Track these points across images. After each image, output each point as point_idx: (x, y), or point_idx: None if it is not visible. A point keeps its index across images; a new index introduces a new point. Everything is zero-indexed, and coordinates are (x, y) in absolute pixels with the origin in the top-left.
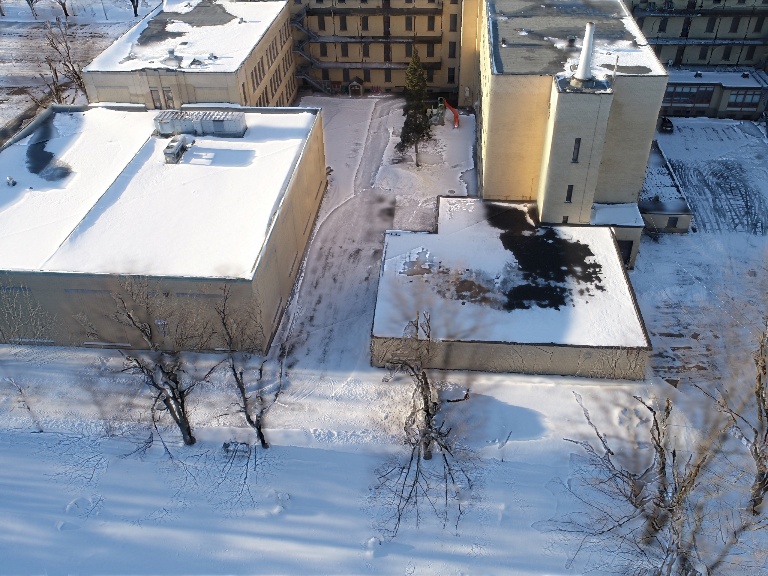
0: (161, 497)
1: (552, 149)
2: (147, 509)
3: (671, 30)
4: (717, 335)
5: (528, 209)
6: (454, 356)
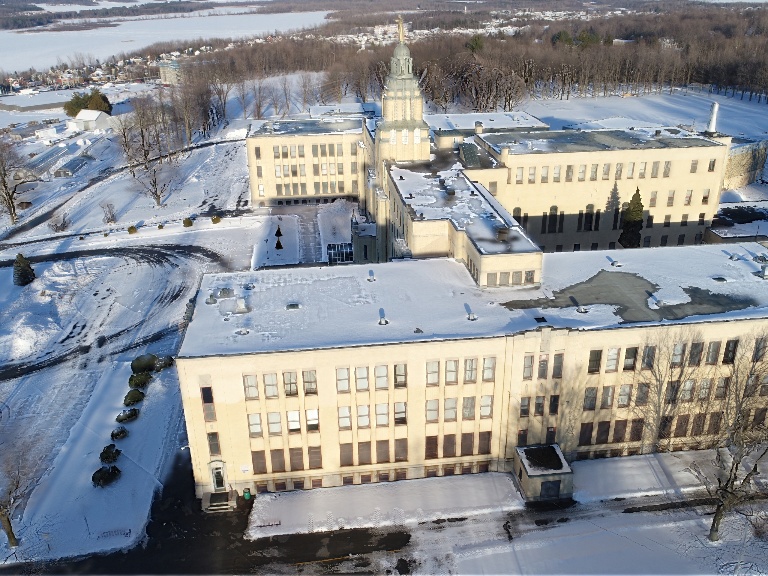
0: None
1: None
2: None
3: None
4: None
5: None
6: None
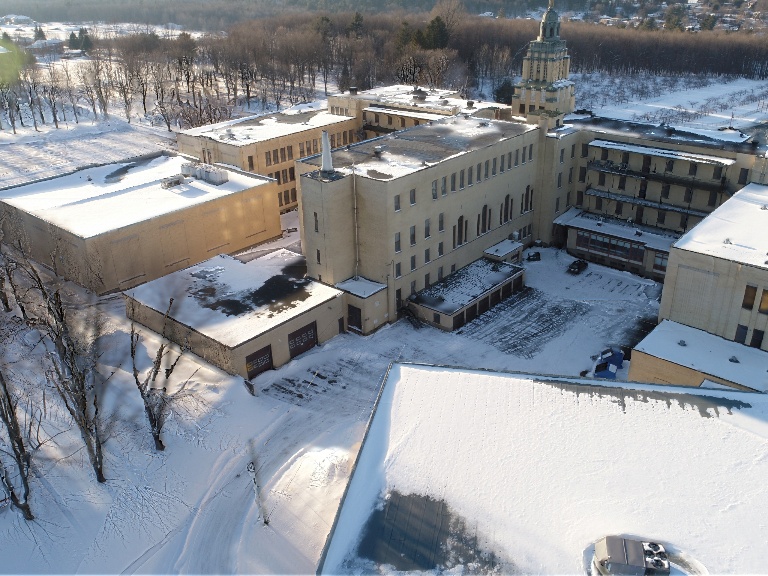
0: None
1: (304, 218)
2: None
3: (629, 189)
4: (346, 387)
5: None
6: None
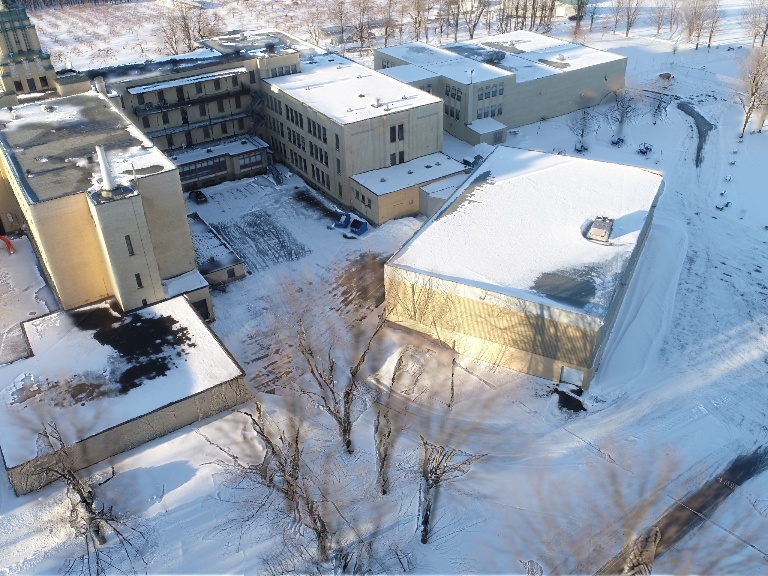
0: None
1: (109, 251)
2: None
3: (173, 121)
4: (291, 344)
5: (110, 305)
6: (93, 451)
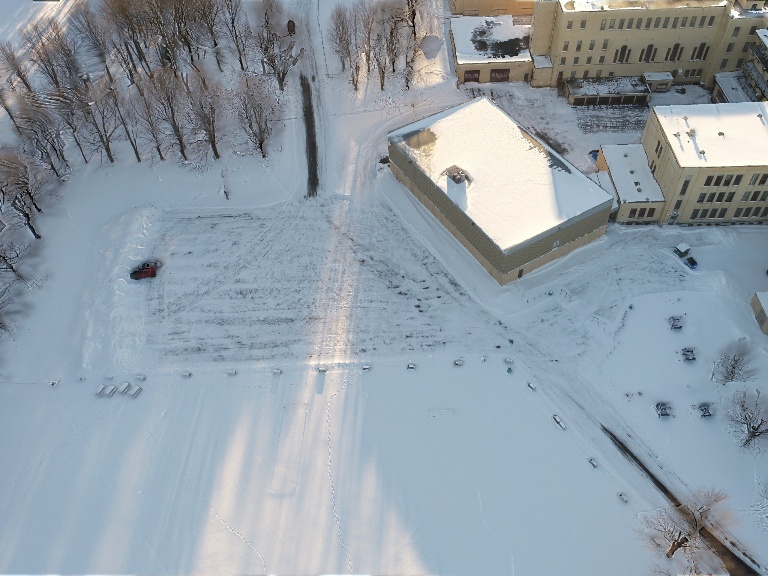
0: (394, 6)
1: None
2: (390, 5)
3: None
4: None
5: None
6: None
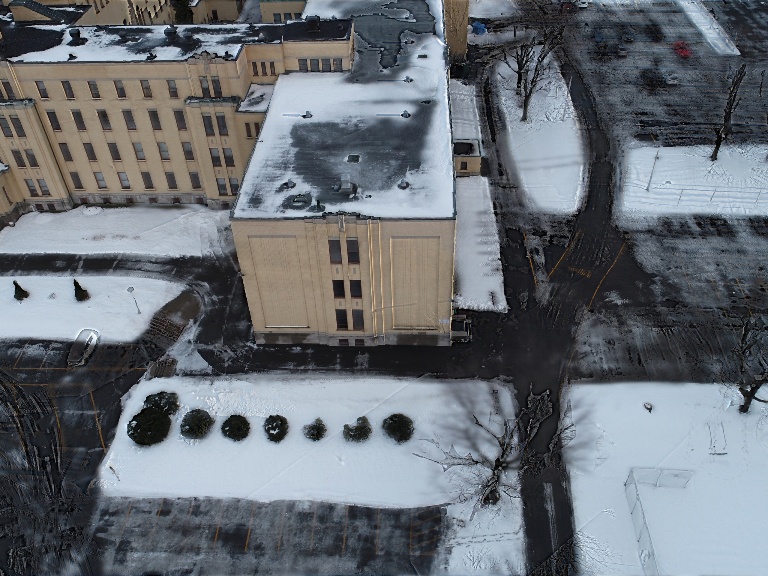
0: None
1: None
2: None
3: None
4: None
5: None
6: None
